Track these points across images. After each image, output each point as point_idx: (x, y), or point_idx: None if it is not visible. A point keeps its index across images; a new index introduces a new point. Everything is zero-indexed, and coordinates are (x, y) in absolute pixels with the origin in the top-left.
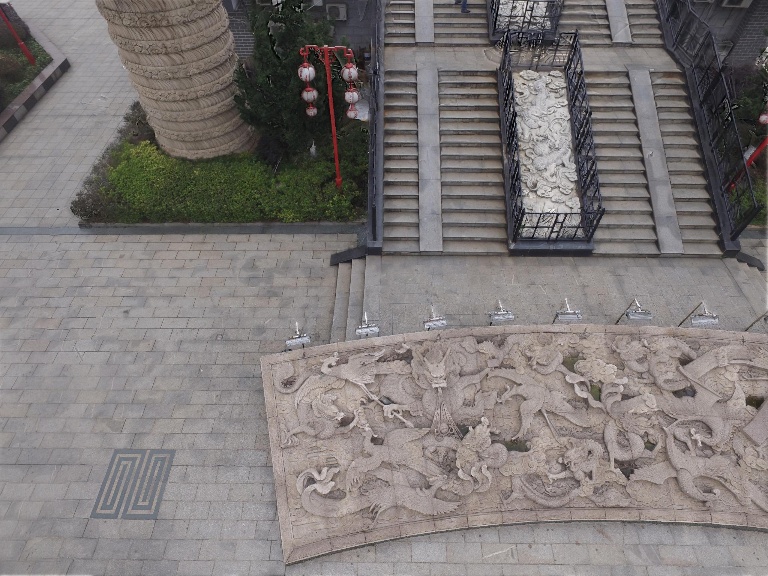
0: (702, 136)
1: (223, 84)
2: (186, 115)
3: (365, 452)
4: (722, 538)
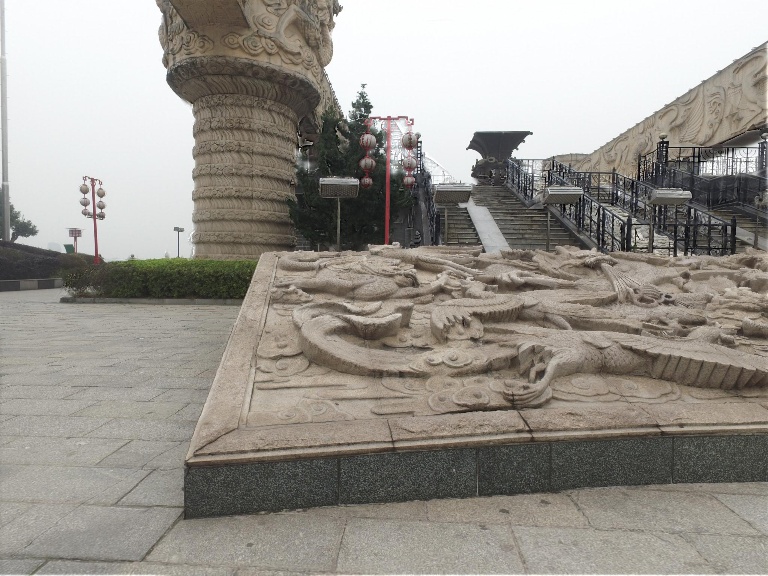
0: None
1: (279, 197)
2: (235, 212)
3: None
4: None
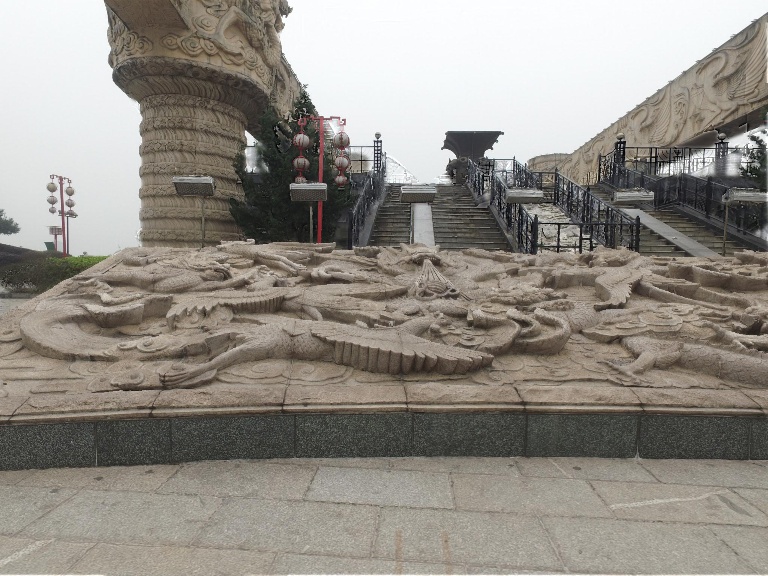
0: None
1: (224, 195)
2: (177, 210)
3: (248, 287)
4: None
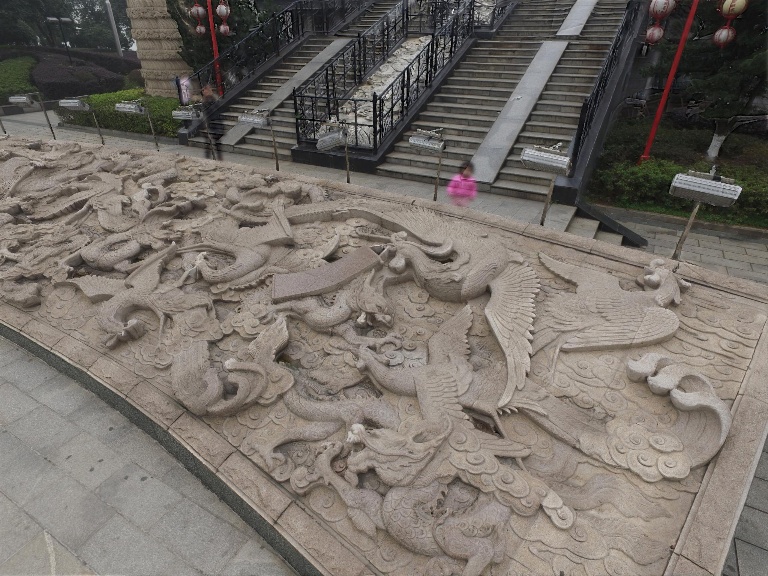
0: None
1: None
2: (151, 53)
3: None
4: (94, 419)
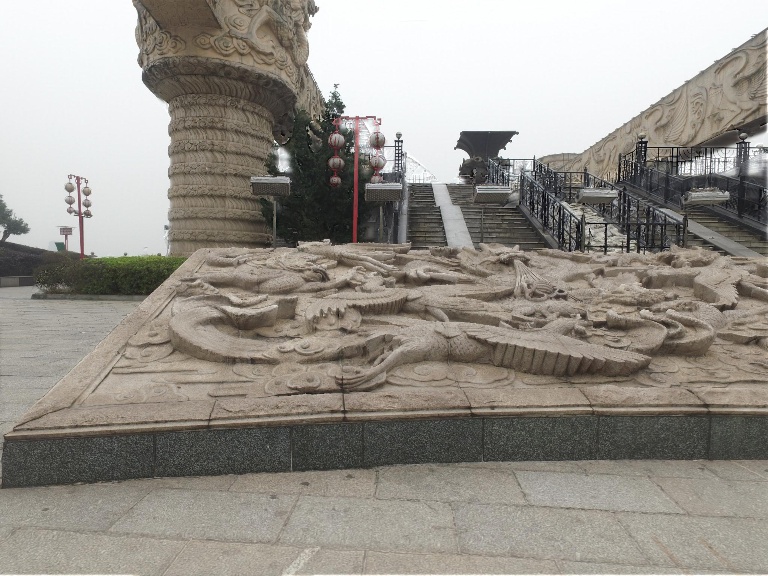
0: (760, 228)
1: None
2: (208, 210)
3: None
4: None
